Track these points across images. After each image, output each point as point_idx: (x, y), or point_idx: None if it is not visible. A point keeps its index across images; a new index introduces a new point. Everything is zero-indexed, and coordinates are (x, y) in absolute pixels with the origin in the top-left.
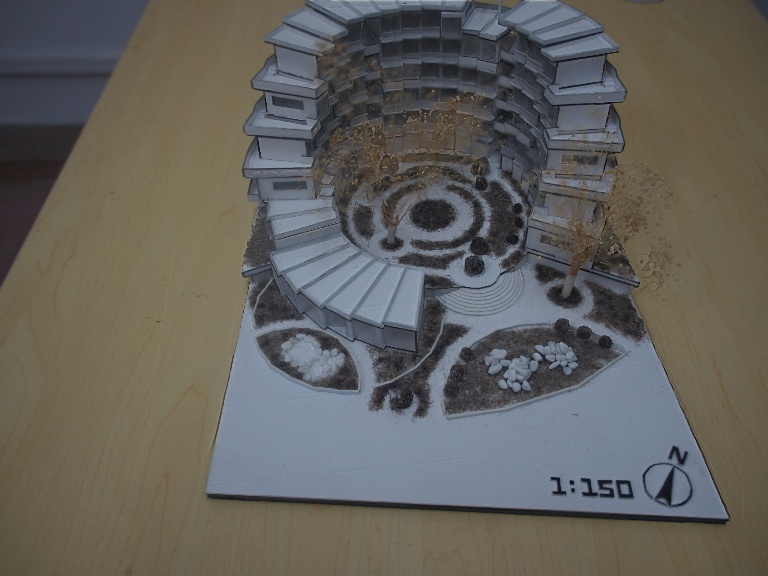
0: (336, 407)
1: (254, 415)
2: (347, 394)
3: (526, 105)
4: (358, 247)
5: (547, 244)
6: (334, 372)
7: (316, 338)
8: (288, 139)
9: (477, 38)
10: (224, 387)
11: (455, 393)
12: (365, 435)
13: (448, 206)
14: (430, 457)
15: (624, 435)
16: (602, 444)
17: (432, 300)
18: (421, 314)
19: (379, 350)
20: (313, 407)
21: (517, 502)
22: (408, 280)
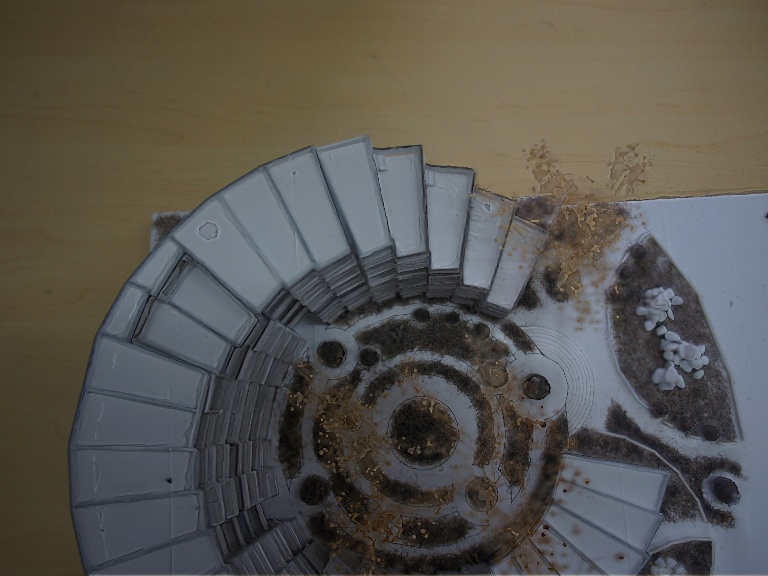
0: (730, 567)
1: None
2: None
3: None
4: None
5: None
6: (684, 570)
7: None
8: None
9: None
10: None
11: None
12: (765, 533)
13: (408, 409)
14: None
15: (753, 261)
16: (765, 285)
17: None
18: None
19: None
20: None
21: None
22: (580, 478)
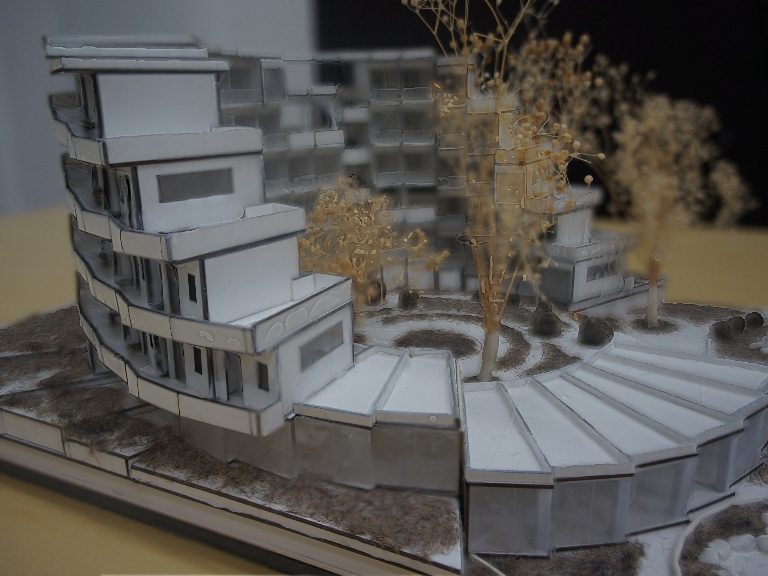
0: None
1: None
2: None
3: (403, 170)
4: None
5: (593, 280)
6: None
7: (719, 538)
8: (266, 243)
9: (307, 99)
10: None
11: None
12: None
13: (429, 330)
14: None
15: None
16: None
17: None
18: None
19: (764, 469)
20: None
21: None
22: None
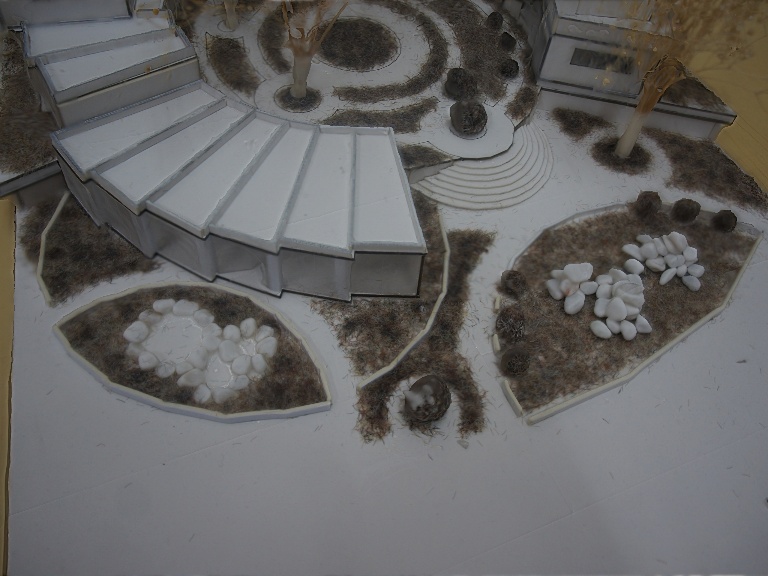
0: (289, 451)
1: (96, 517)
2: (305, 415)
3: None
4: (243, 105)
5: (582, 66)
6: (261, 371)
7: (199, 303)
8: None
9: None
10: (1, 458)
11: (528, 366)
12: (375, 502)
13: (377, 27)
14: (528, 518)
15: None
16: None
17: None
18: None
19: (341, 305)
20: (237, 463)
21: (734, 574)
22: (367, 155)
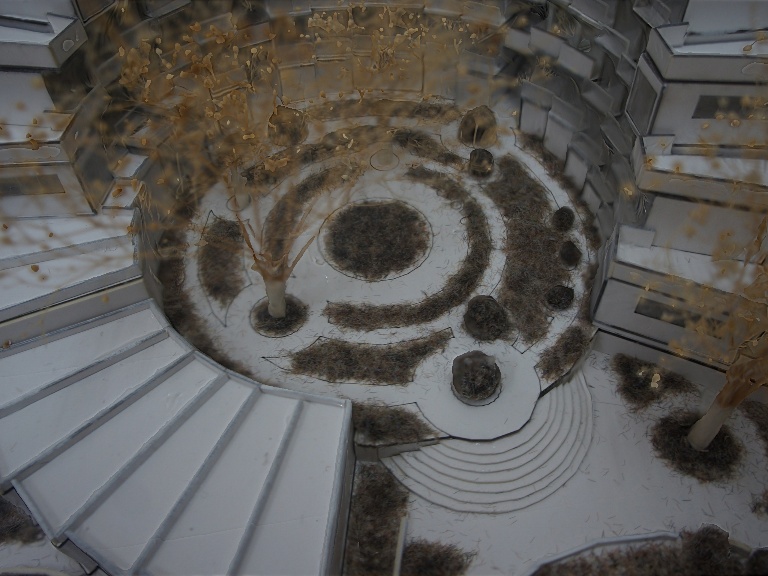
0: None
1: None
2: None
3: None
4: None
5: (652, 318)
6: None
7: None
8: None
9: None
10: None
11: None
12: None
13: (411, 216)
14: None
15: None
16: None
17: (374, 467)
18: (345, 517)
19: None
20: None
21: None
22: (306, 438)
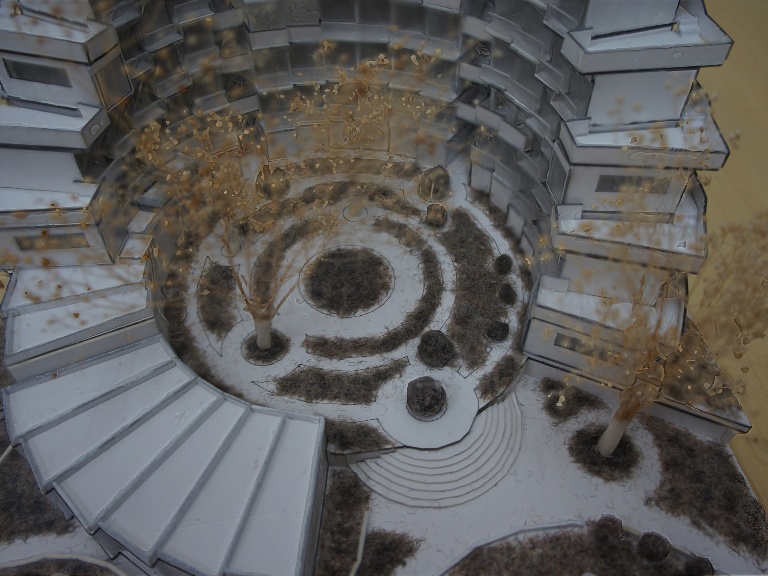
0: None
1: None
2: None
3: (517, 72)
4: None
5: (568, 349)
6: None
7: None
8: (38, 149)
9: None
10: None
11: None
12: None
13: (376, 262)
14: None
15: None
16: None
17: (343, 471)
18: (319, 511)
19: None
20: None
21: None
22: (288, 448)
